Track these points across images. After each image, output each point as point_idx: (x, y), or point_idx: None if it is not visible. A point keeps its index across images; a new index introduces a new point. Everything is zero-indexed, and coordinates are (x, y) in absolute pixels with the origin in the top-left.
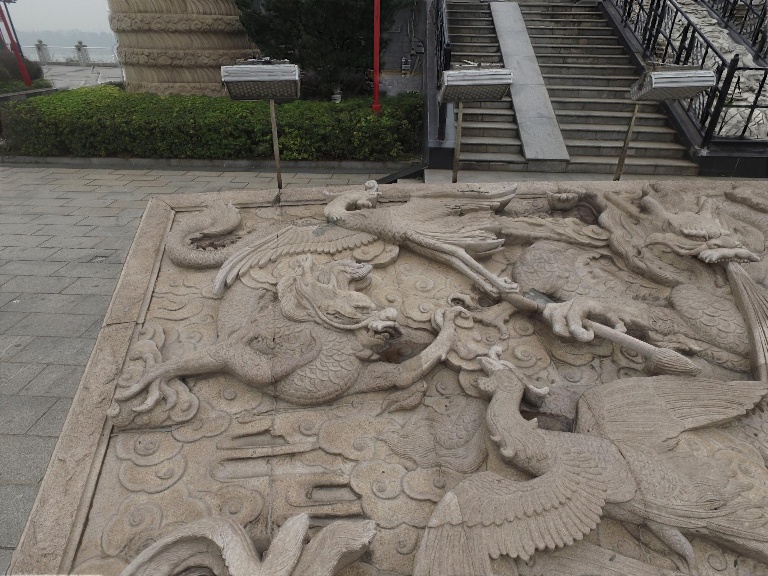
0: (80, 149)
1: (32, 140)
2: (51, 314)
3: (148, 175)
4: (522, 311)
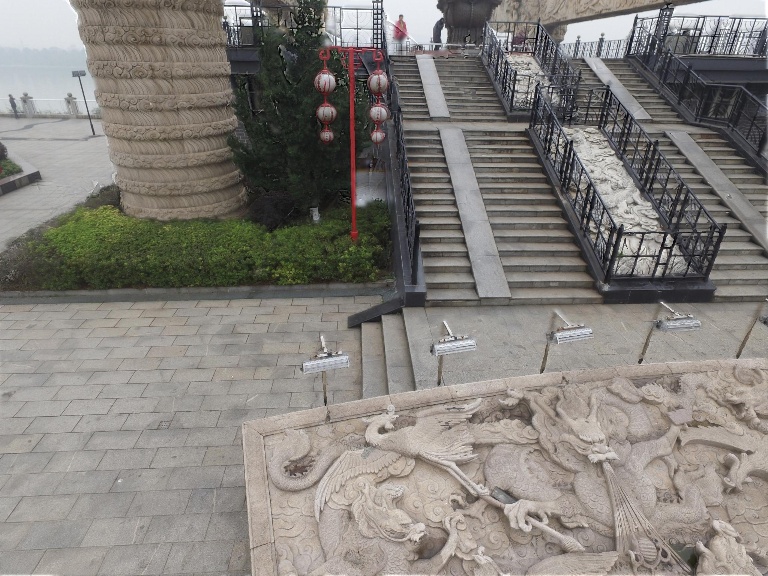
0: (98, 283)
1: (53, 278)
2: (153, 492)
3: (165, 309)
4: (492, 505)
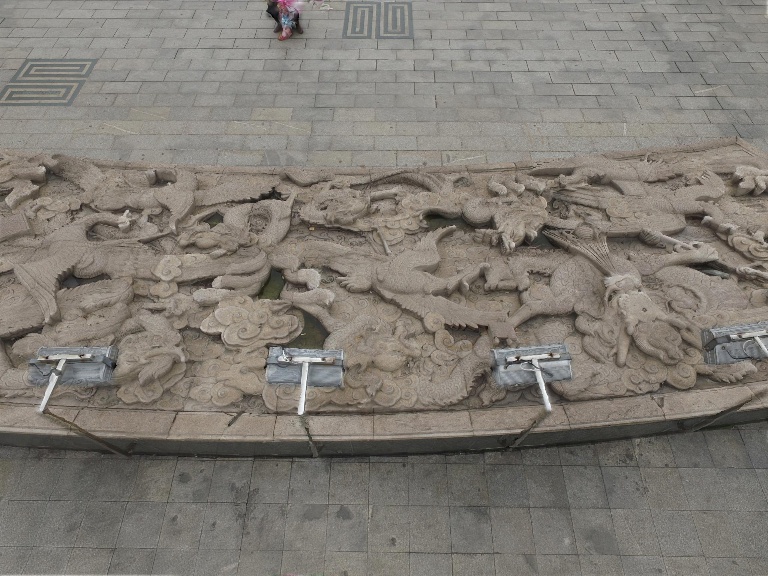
0: None
1: None
2: None
3: None
4: None
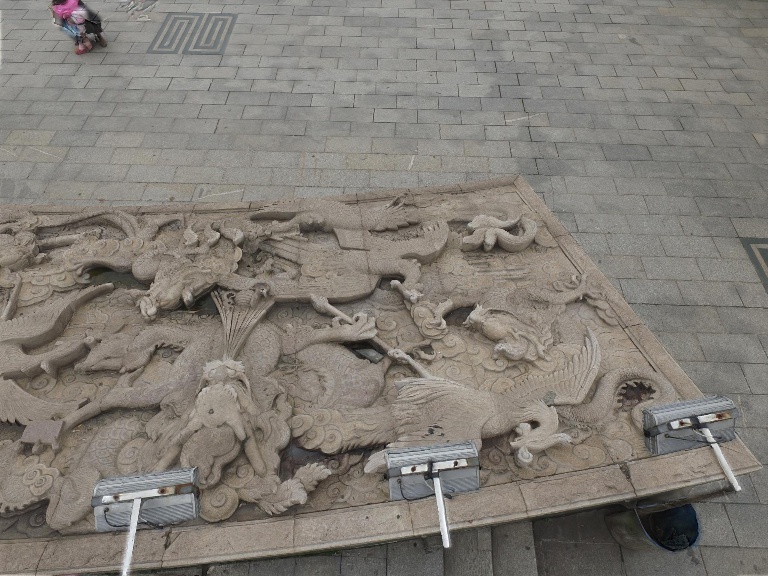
0: None
1: None
2: None
3: None
4: None
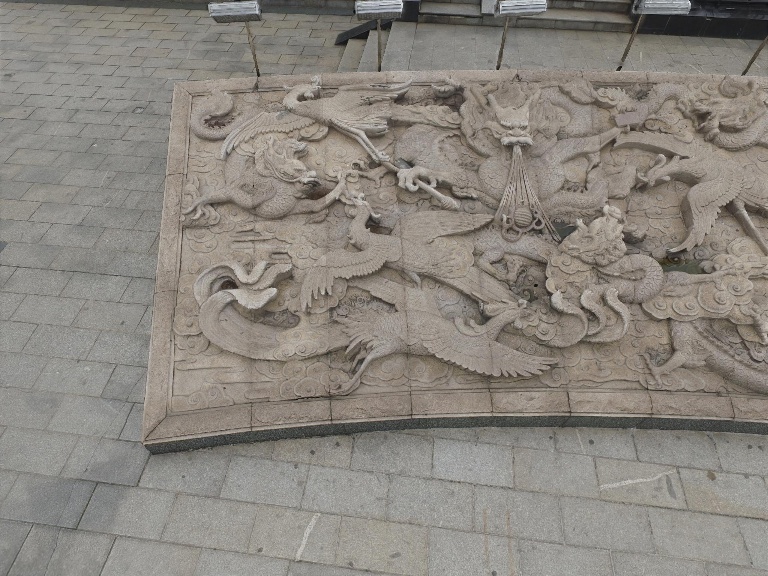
0: None
1: None
2: (121, 156)
3: (156, 15)
4: (391, 172)
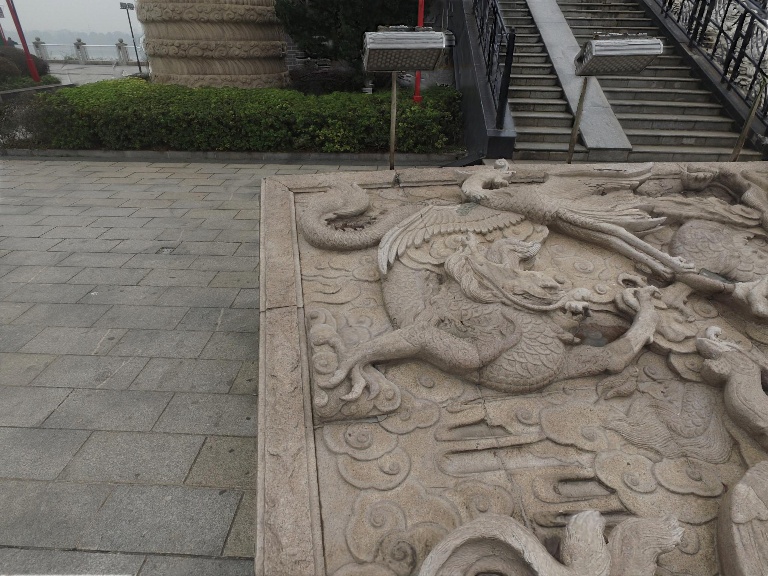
0: (114, 142)
1: (64, 132)
2: (136, 306)
3: (188, 168)
4: (700, 292)
